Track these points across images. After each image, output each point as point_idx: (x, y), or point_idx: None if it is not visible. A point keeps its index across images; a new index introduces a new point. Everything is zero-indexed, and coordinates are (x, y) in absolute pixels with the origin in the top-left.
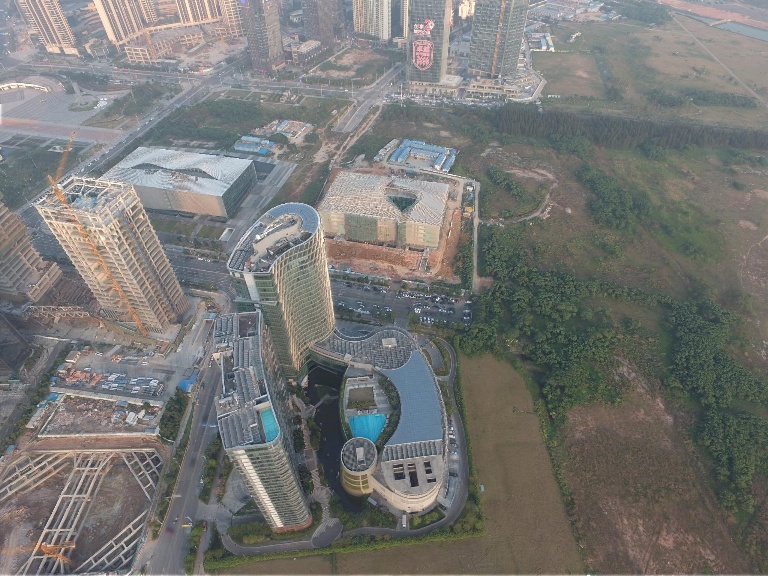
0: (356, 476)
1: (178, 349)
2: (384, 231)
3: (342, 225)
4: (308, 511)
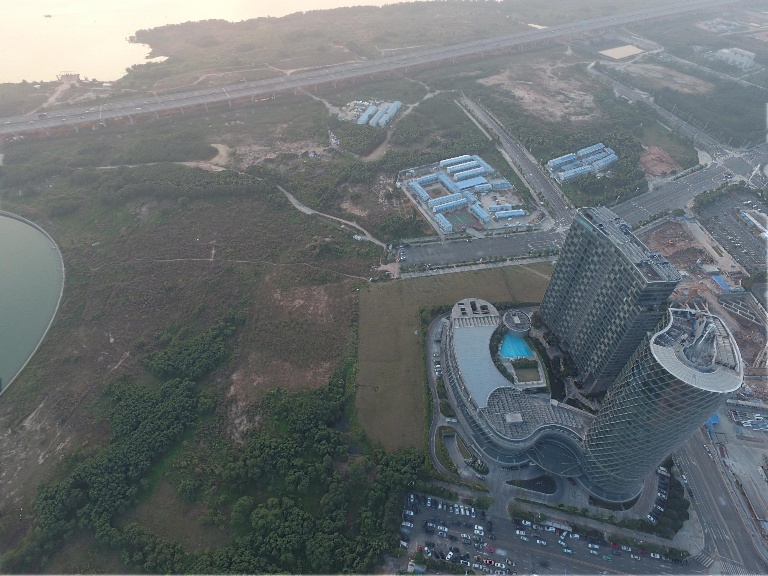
0: None
1: (762, 469)
2: None
3: None
4: None
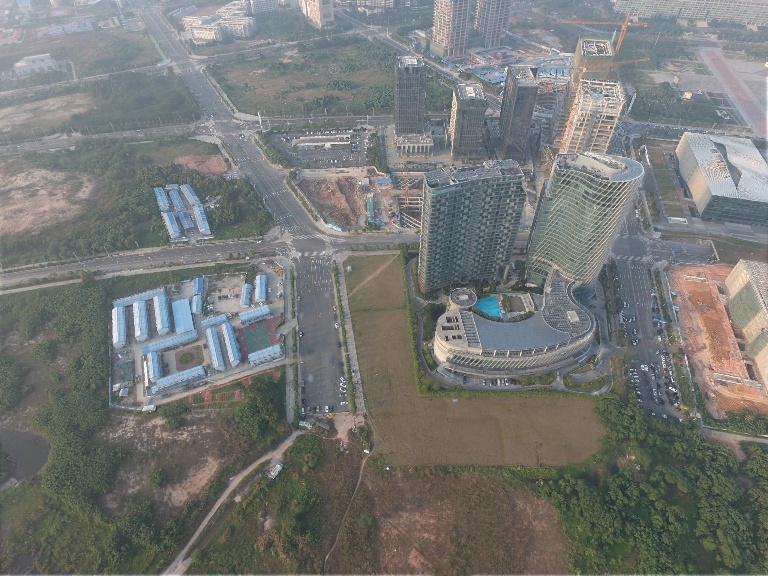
0: None
1: None
2: (754, 328)
3: (738, 290)
4: (426, 280)
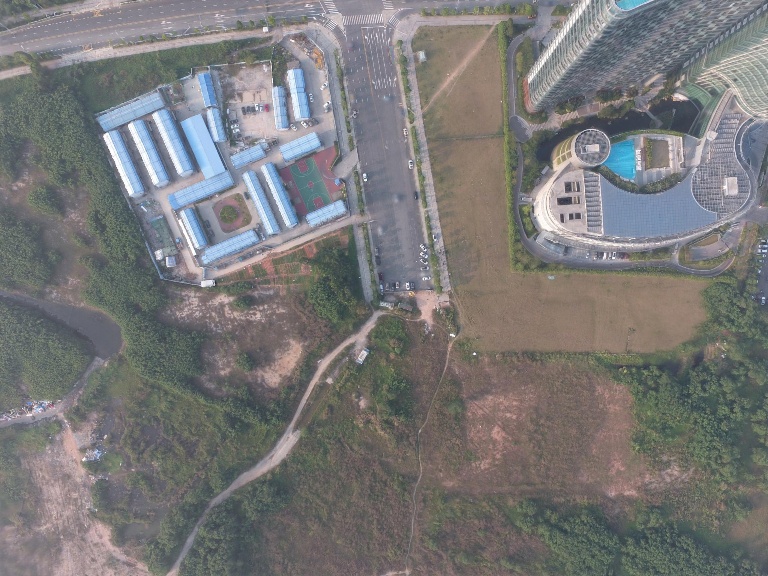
0: (570, 146)
1: None
2: None
3: None
4: (541, 103)
